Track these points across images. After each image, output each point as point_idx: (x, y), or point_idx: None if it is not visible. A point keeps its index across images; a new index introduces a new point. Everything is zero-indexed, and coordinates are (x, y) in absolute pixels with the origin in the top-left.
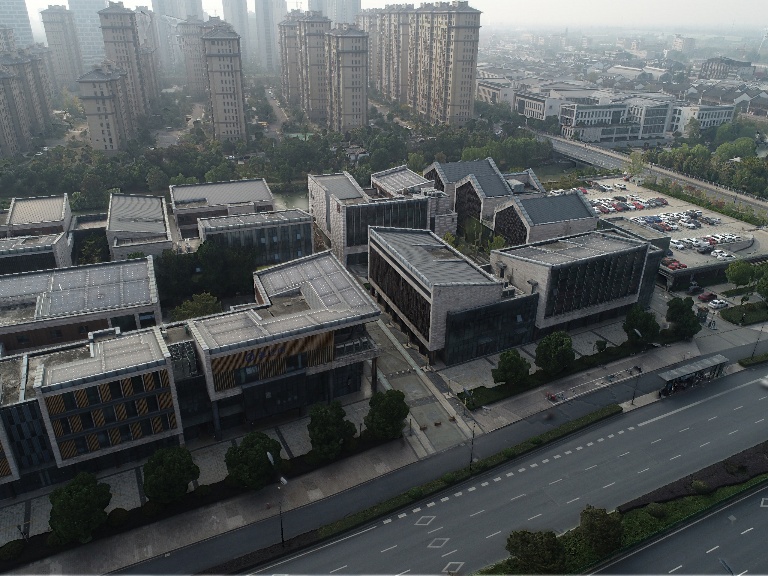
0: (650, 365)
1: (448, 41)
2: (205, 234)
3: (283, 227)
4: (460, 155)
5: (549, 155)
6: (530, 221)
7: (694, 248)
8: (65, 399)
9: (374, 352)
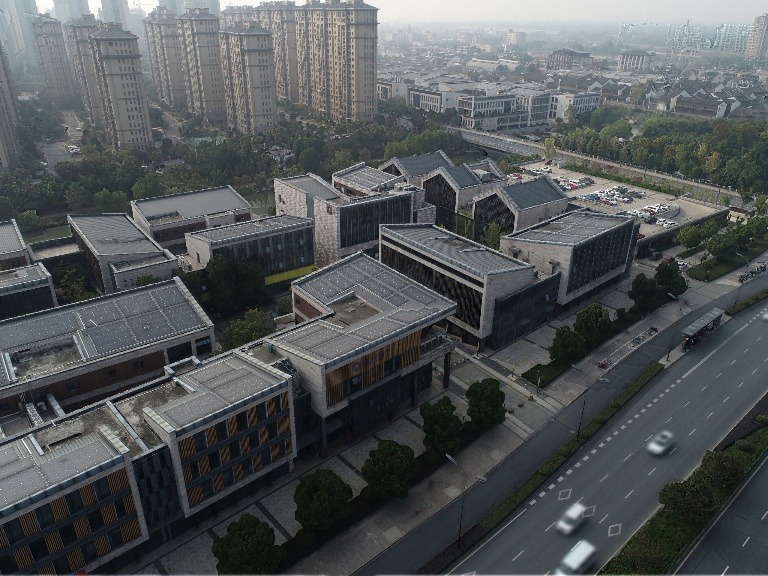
0: (660, 325)
1: (347, 38)
2: (211, 249)
3: (287, 234)
4: (380, 150)
5: (460, 145)
6: (517, 207)
7: (639, 219)
8: (195, 440)
9: (450, 346)
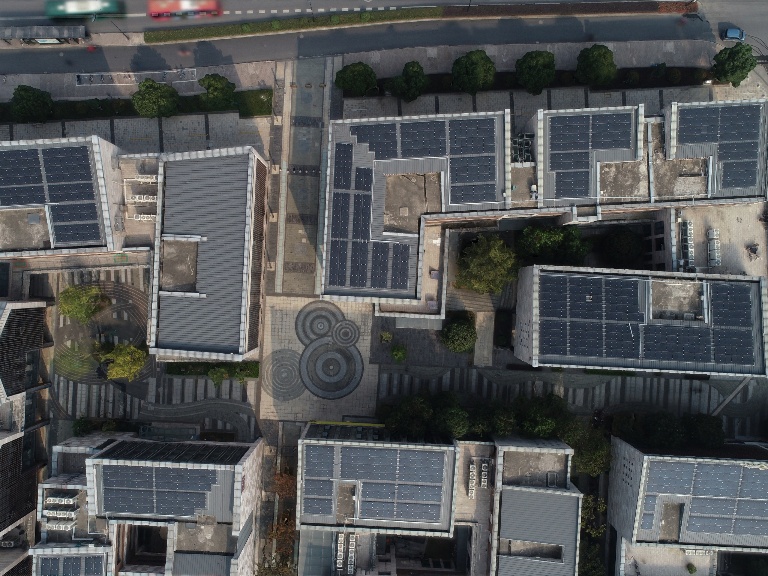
0: (60, 81)
1: None
2: None
3: None
4: None
5: None
6: None
7: None
8: None
9: None
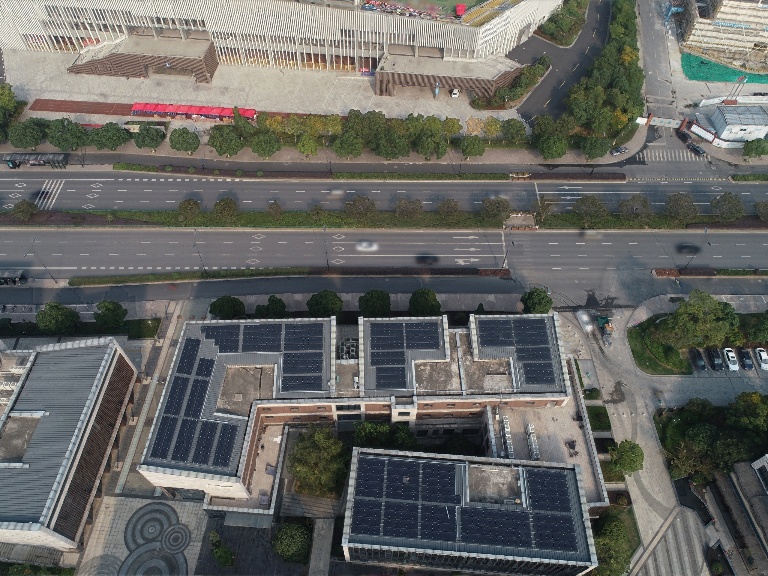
0: None
1: None
2: None
3: None
4: None
5: None
6: None
7: None
8: None
9: None
